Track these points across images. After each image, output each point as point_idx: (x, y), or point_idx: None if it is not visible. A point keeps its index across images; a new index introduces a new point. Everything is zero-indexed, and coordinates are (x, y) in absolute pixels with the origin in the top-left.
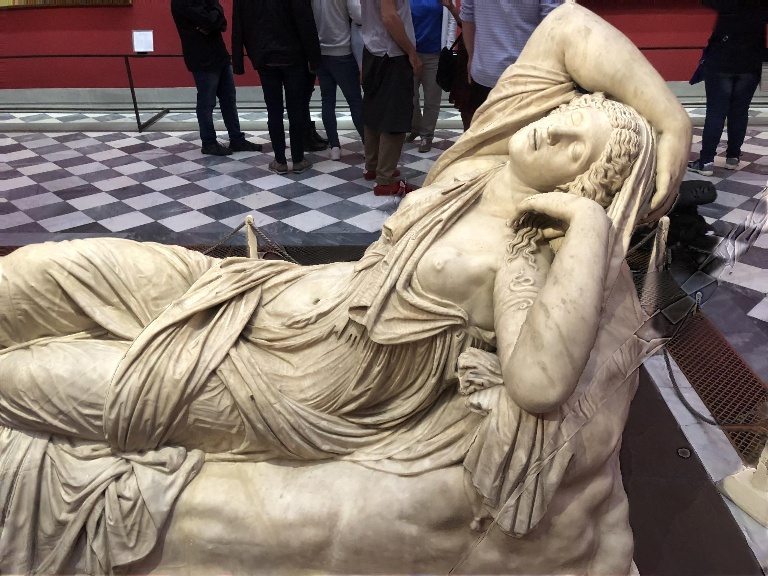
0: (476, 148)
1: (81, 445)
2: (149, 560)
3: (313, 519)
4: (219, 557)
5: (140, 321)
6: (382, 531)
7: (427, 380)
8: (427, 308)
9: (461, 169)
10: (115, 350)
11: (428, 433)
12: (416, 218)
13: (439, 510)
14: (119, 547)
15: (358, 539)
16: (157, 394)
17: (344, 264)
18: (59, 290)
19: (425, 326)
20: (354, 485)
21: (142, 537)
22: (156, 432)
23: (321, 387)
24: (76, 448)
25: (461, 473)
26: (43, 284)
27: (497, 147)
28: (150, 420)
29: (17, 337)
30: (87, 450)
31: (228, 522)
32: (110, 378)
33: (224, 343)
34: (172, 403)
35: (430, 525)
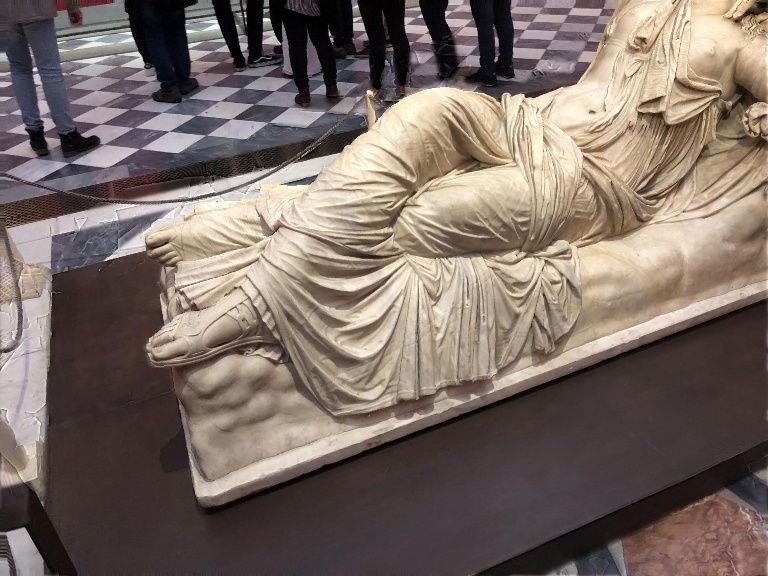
0: None
1: (504, 255)
2: None
3: (670, 261)
4: (613, 311)
5: (490, 151)
6: (716, 254)
7: (689, 150)
8: (704, 87)
9: None
10: (507, 171)
11: (698, 188)
12: (662, 25)
13: (750, 226)
14: (562, 320)
15: (702, 265)
16: (564, 192)
17: (575, 85)
18: (449, 131)
19: (699, 103)
20: (677, 233)
21: (568, 311)
22: (559, 227)
23: (630, 171)
24: None
25: (761, 195)
26: (442, 126)
27: None
28: None
29: (419, 182)
30: (514, 255)
31: (617, 282)
32: (528, 188)
33: (574, 148)
34: (571, 198)
35: (743, 239)
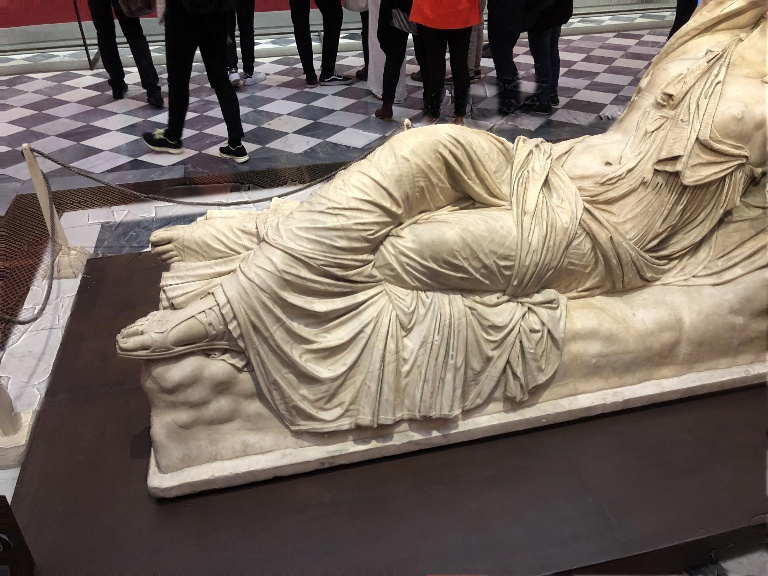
0: (714, 25)
1: (485, 296)
2: (546, 381)
3: (667, 325)
4: (598, 368)
5: (489, 192)
6: (719, 324)
7: (709, 213)
8: (727, 151)
9: (703, 43)
10: (499, 213)
11: (714, 254)
12: (692, 84)
13: (761, 300)
14: (537, 370)
15: (702, 334)
16: (554, 241)
17: (599, 135)
18: (444, 167)
19: (721, 167)
20: (682, 298)
21: (546, 361)
22: (547, 275)
23: (639, 228)
24: (483, 299)
25: None
26: (436, 162)
27: (735, 22)
28: (549, 264)
29: (408, 214)
30: (495, 298)
31: (605, 339)
32: (516, 233)
33: (576, 199)
34: (563, 248)
35: (752, 314)
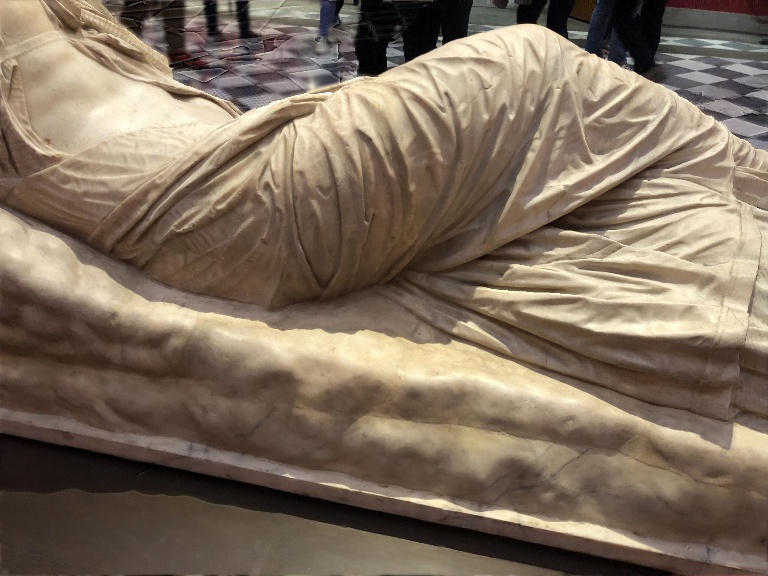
0: None
1: None
2: None
3: None
4: None
5: None
6: None
7: None
8: None
9: None
10: None
11: None
12: None
13: None
14: None
15: None
16: None
17: (118, 119)
18: None
19: None
20: None
21: None
22: None
23: None
24: None
25: None
26: None
27: None
28: None
29: None
30: None
31: None
32: None
33: None
34: None
35: None
